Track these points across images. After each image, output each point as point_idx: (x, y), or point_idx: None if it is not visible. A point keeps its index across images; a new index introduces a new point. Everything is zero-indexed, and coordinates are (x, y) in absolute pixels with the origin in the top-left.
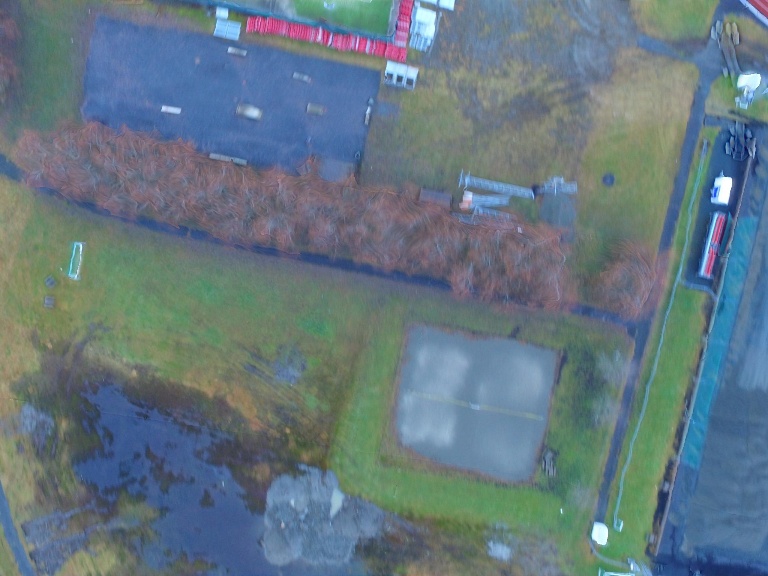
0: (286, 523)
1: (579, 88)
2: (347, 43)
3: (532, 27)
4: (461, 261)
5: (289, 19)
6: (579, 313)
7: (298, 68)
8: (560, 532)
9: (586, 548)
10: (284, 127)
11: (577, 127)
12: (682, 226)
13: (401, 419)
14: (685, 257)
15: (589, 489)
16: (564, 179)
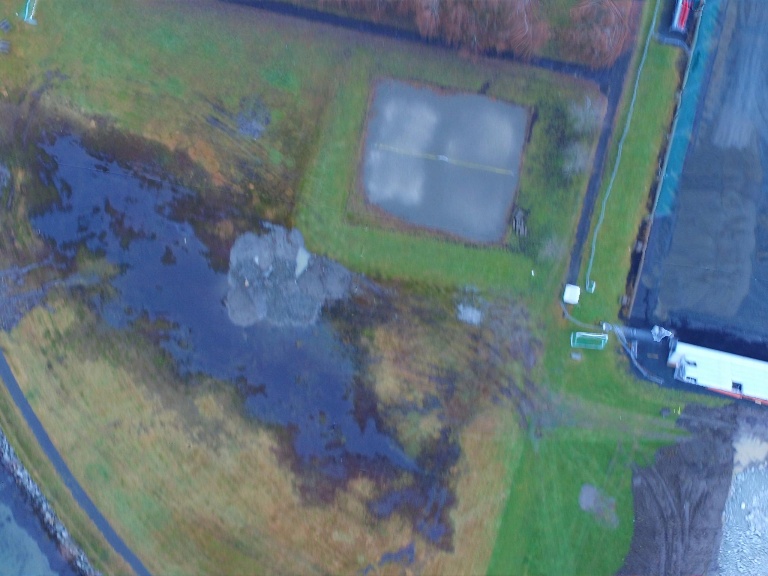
0: (250, 281)
1: None
2: None
3: None
4: None
5: None
6: (550, 69)
7: None
8: (531, 295)
9: (558, 311)
10: None
11: None
12: None
13: (368, 176)
14: (658, 11)
15: (561, 251)
16: None
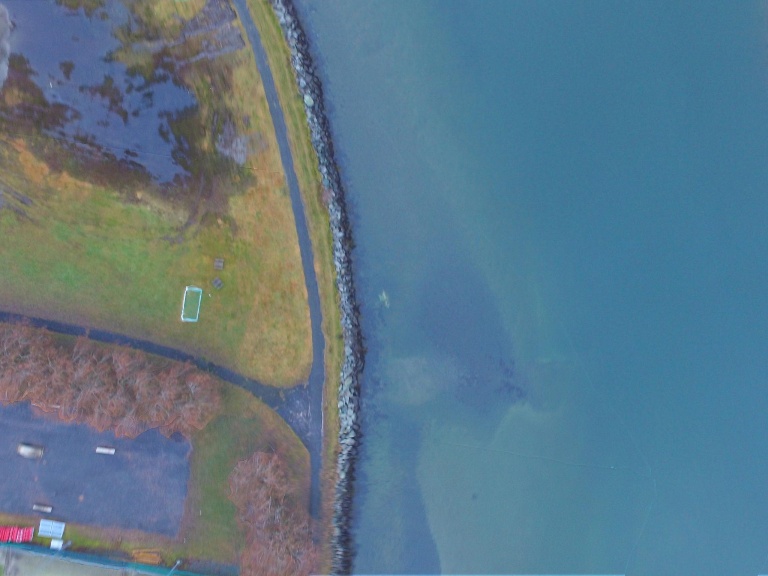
0: None
1: None
2: None
3: None
4: None
5: None
6: None
7: None
8: None
9: None
10: None
11: None
12: None
13: None
14: None
15: None
16: None
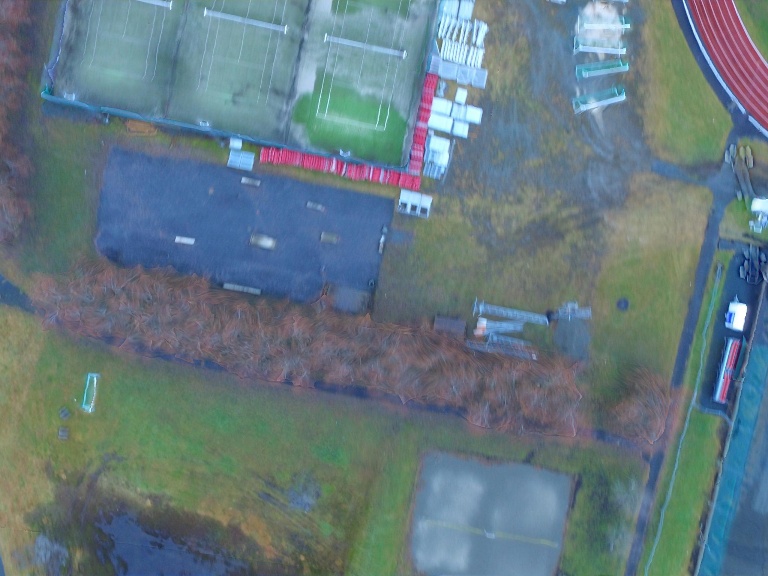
0: None
1: (593, 213)
2: (361, 172)
3: (546, 153)
4: (477, 402)
5: (303, 149)
6: (594, 438)
7: (312, 197)
8: None
9: None
10: (298, 256)
11: (591, 252)
12: (696, 350)
13: (416, 545)
14: (700, 381)
15: None
16: (578, 304)
